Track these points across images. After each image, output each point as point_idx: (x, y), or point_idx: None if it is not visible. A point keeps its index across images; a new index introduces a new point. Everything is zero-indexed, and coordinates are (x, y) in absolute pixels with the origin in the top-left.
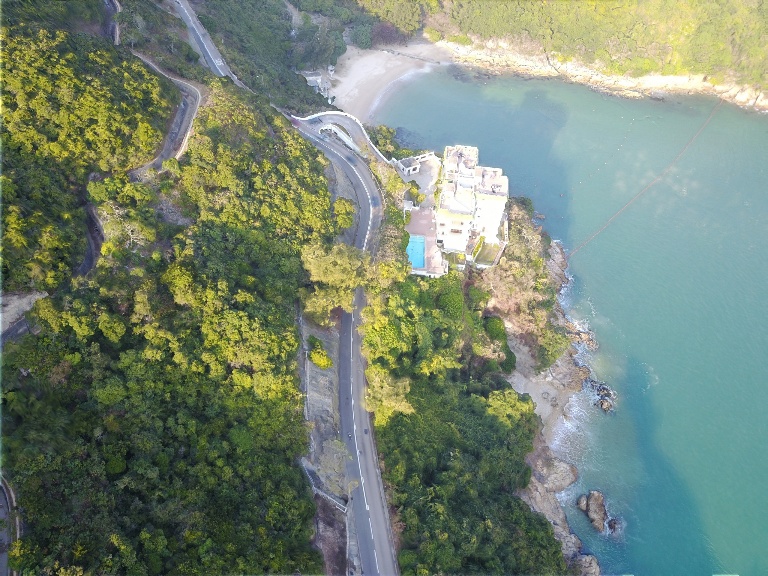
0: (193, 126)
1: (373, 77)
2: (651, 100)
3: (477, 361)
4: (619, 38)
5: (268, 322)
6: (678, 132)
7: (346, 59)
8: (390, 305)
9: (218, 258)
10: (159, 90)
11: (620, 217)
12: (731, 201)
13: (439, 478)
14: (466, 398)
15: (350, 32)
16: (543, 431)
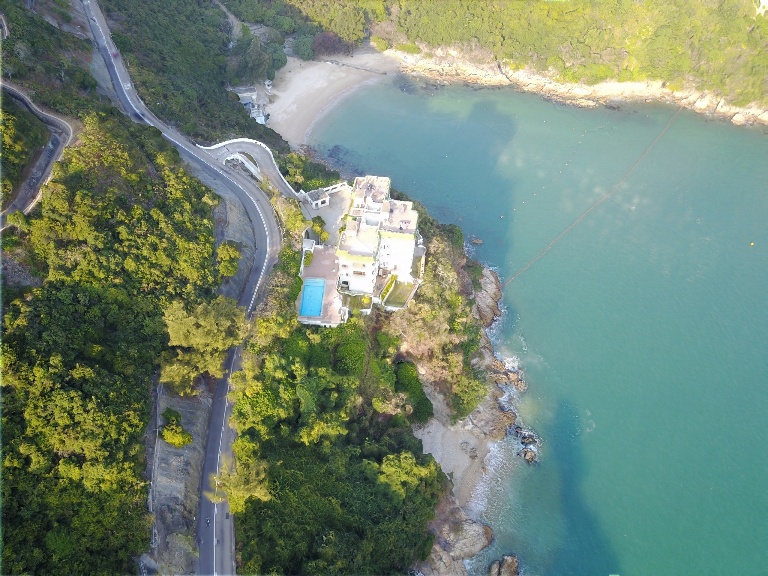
0: (53, 171)
1: (314, 91)
2: (606, 109)
3: (382, 415)
4: (572, 44)
5: (110, 399)
6: (632, 143)
7: (287, 72)
8: (266, 367)
9: (60, 326)
10: (14, 132)
11: (562, 240)
12: (682, 219)
13: (305, 569)
14: (358, 464)
15: (292, 43)
16: (458, 487)
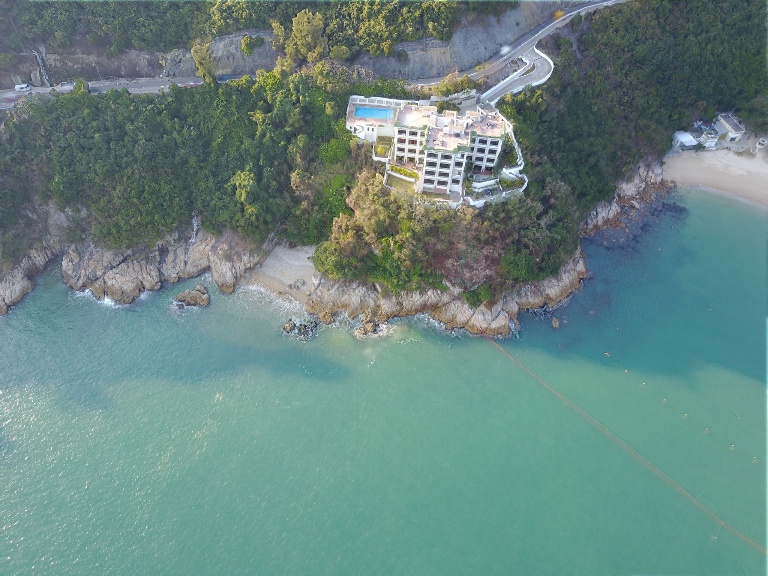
0: None
1: None
2: None
3: None
4: None
5: None
6: None
7: None
8: None
9: None
10: None
11: (580, 415)
12: None
13: None
14: None
15: None
16: (267, 275)
